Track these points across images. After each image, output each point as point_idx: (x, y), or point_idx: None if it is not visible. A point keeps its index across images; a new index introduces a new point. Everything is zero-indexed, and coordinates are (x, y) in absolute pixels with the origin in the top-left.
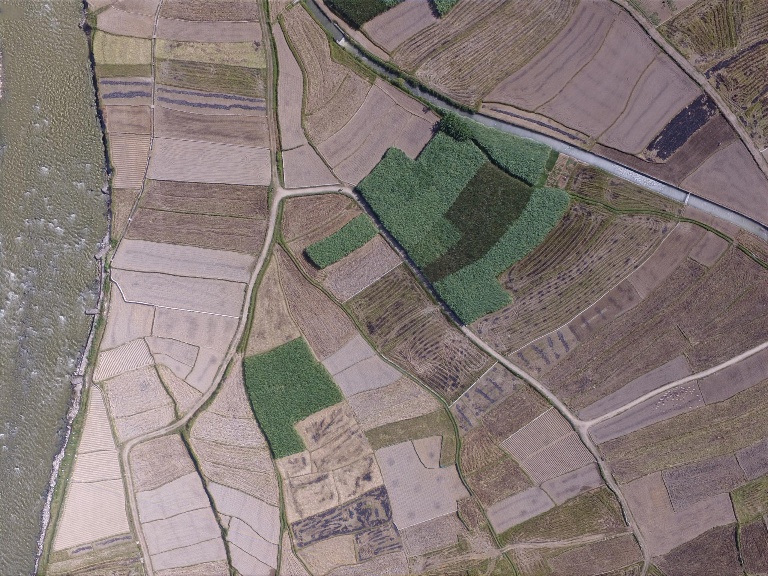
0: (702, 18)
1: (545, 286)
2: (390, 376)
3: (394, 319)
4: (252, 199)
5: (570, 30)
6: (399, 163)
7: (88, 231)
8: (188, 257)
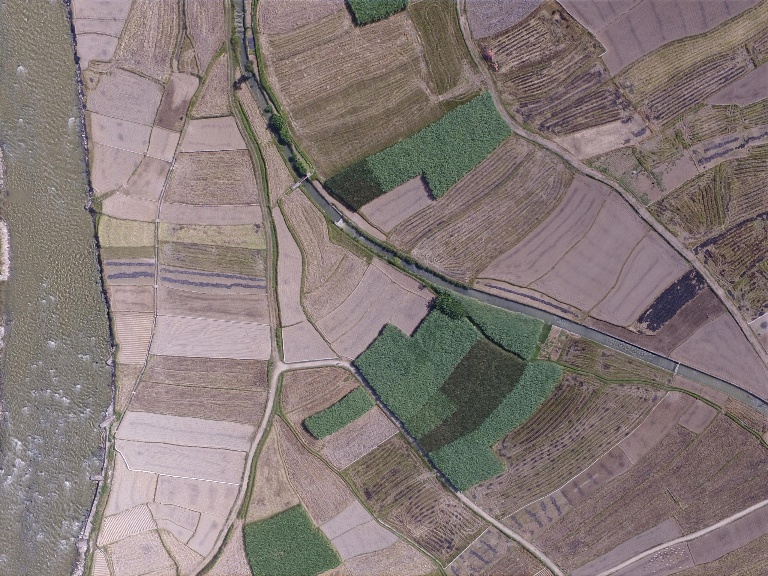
0: (691, 198)
1: (538, 453)
2: (387, 540)
3: (391, 485)
4: (252, 372)
5: (562, 210)
6: (395, 340)
7: (93, 401)
8: (190, 428)
